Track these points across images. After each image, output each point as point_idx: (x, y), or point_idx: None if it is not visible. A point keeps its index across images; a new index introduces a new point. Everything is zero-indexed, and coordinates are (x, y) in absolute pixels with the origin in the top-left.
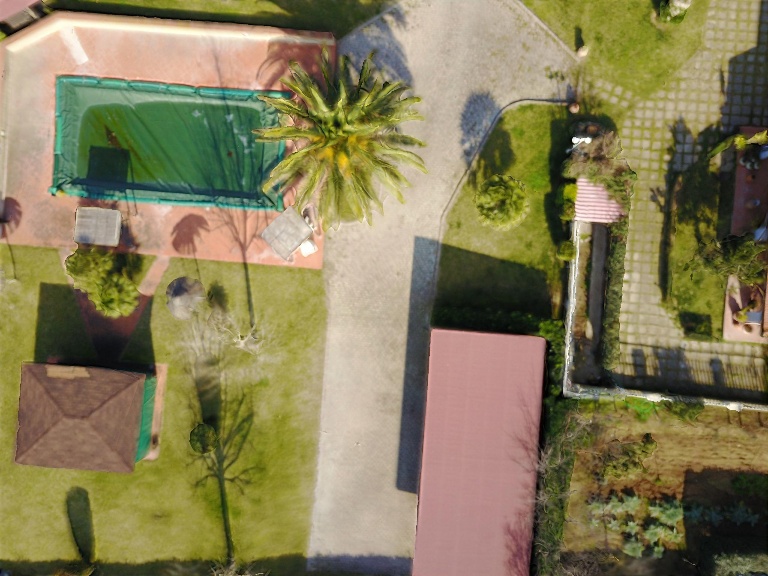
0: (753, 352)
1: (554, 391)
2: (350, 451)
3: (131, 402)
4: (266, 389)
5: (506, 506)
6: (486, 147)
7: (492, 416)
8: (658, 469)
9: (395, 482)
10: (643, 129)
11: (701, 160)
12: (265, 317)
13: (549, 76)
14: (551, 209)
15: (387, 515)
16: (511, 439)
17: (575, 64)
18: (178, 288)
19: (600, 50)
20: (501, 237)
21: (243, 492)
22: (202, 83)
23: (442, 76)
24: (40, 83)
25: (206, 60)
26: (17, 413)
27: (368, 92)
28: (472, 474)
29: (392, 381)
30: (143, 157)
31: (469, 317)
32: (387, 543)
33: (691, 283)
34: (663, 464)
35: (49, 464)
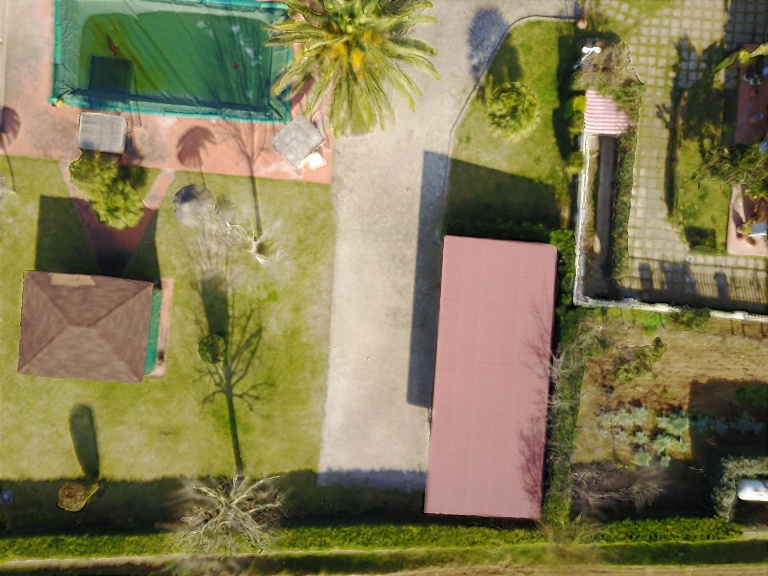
0: (756, 265)
1: (564, 300)
2: (360, 366)
3: (138, 311)
4: (274, 304)
5: (518, 412)
6: (495, 63)
7: (504, 322)
8: (664, 380)
9: (405, 396)
10: (649, 46)
11: (705, 77)
12: (273, 232)
13: None
14: (559, 124)
15: (397, 429)
16: (523, 345)
17: None
18: (186, 195)
19: None
20: (510, 152)
21: (251, 408)
22: None
23: None
24: None
25: None
26: (16, 330)
27: None
28: (485, 380)
29: (402, 296)
30: (147, 69)
31: (480, 226)
32: (397, 457)
33: (696, 197)
34: (669, 375)
35: (53, 374)
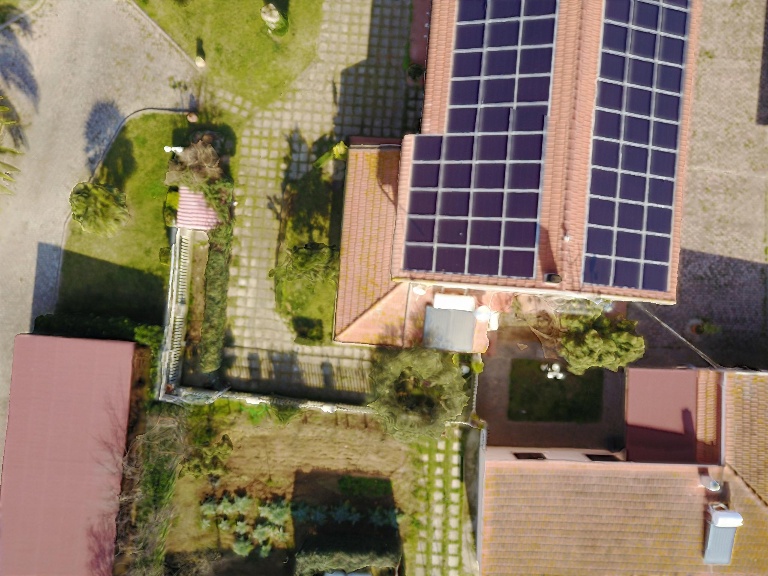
0: (361, 355)
1: (150, 394)
2: None
3: None
4: None
5: (90, 507)
6: (110, 155)
7: (78, 419)
8: (270, 470)
9: None
10: (261, 138)
11: (314, 169)
12: None
13: (172, 86)
14: None
15: None
16: (96, 442)
17: (197, 74)
18: None
19: (220, 61)
20: (121, 243)
21: None
22: None
23: (68, 85)
24: None
25: None
26: None
27: None
28: (55, 476)
29: None
30: None
31: (67, 322)
32: None
33: (304, 288)
34: (274, 465)
35: None
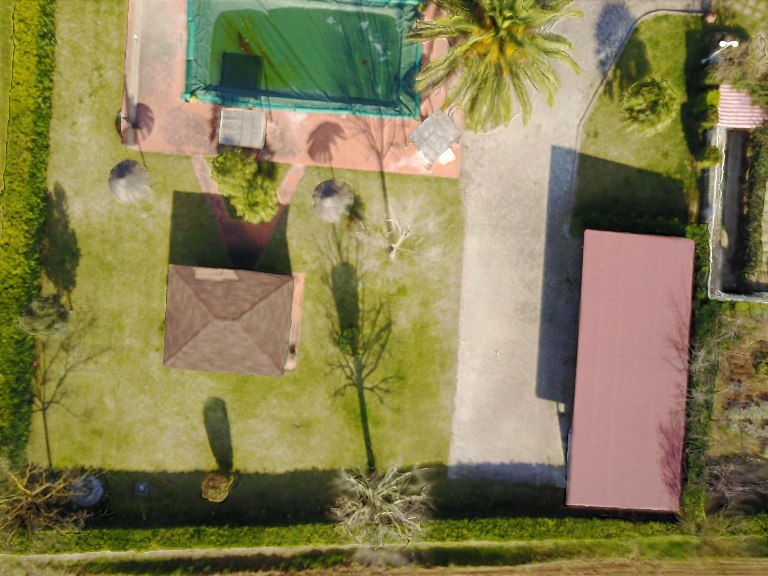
0: None
1: (699, 294)
2: (489, 359)
3: (280, 305)
4: (404, 298)
5: (657, 405)
6: (622, 57)
7: (643, 316)
8: None
9: (534, 390)
10: None
11: None
12: None
13: None
14: (687, 118)
15: (526, 422)
16: (662, 339)
17: None
18: (327, 190)
19: None
20: (638, 146)
21: (382, 401)
22: None
23: None
24: None
25: None
26: (151, 323)
27: None
28: (625, 373)
29: (530, 290)
30: (277, 64)
31: (616, 220)
32: (526, 450)
33: None
34: None
35: (198, 367)
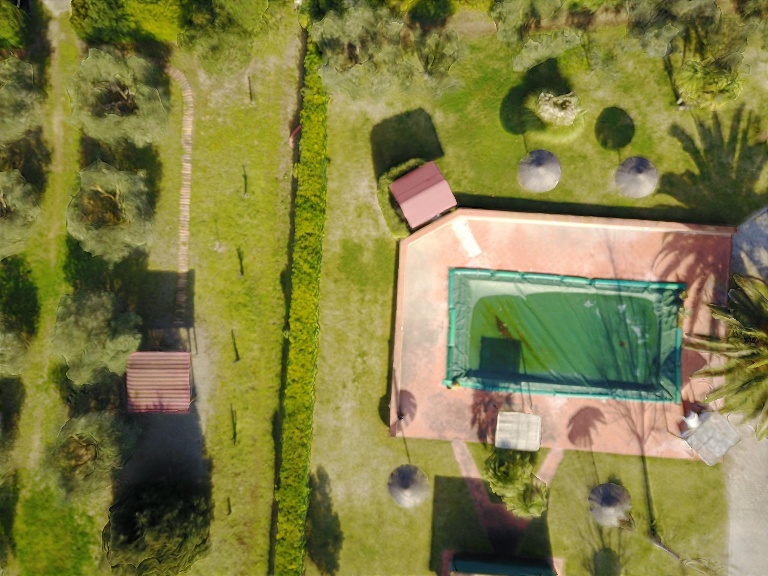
0: None
1: None
2: None
3: None
4: None
5: None
6: None
7: None
8: None
9: None
10: None
11: None
12: (664, 512)
13: None
14: None
15: None
16: None
17: None
18: (607, 497)
19: None
20: None
21: None
22: (596, 274)
23: None
24: (433, 276)
25: (599, 252)
26: None
27: (764, 282)
28: None
29: None
30: (535, 348)
31: None
32: None
33: None
34: None
35: None
